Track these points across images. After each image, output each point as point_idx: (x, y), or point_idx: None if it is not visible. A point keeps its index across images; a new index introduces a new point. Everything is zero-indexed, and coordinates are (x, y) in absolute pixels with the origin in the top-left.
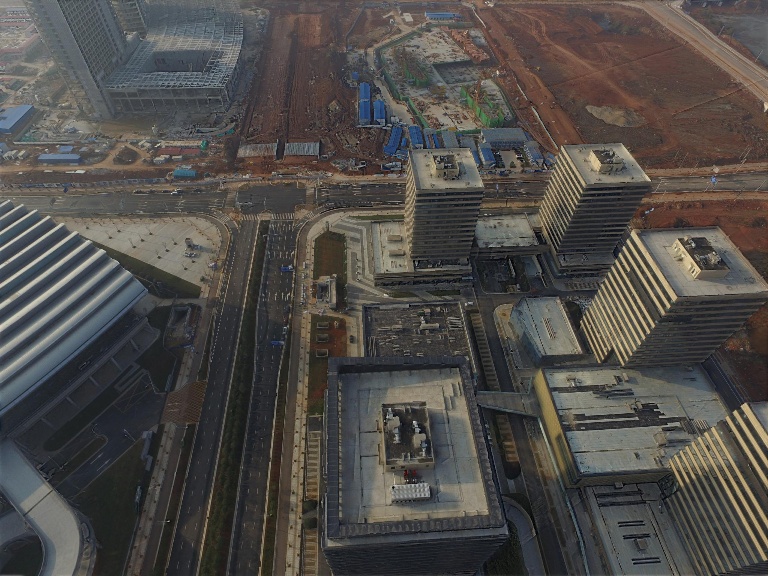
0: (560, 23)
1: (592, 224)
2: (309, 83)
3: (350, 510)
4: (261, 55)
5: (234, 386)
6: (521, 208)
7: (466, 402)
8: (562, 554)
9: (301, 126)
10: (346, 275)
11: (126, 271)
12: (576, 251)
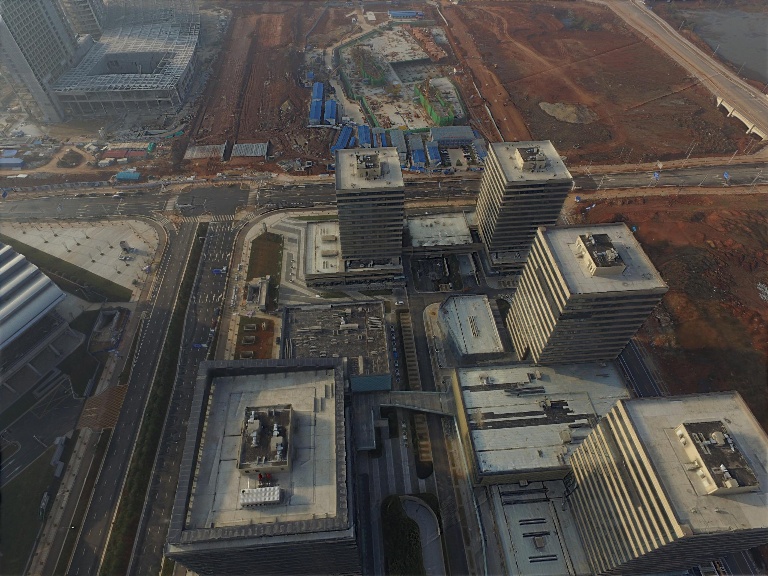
0: (522, 20)
1: (520, 222)
2: (264, 83)
3: (199, 515)
4: (219, 56)
5: (153, 390)
6: (463, 206)
7: (335, 404)
8: (465, 553)
9: (251, 127)
10: (279, 276)
11: (44, 276)
12: (508, 249)
